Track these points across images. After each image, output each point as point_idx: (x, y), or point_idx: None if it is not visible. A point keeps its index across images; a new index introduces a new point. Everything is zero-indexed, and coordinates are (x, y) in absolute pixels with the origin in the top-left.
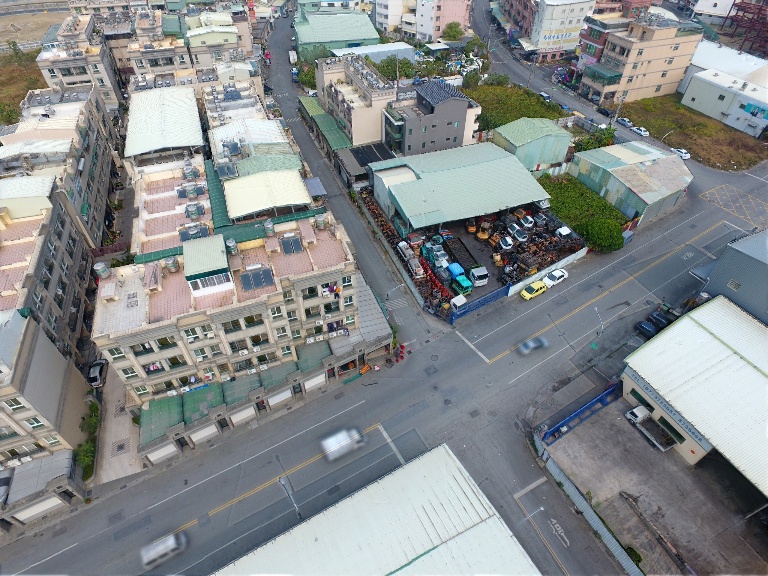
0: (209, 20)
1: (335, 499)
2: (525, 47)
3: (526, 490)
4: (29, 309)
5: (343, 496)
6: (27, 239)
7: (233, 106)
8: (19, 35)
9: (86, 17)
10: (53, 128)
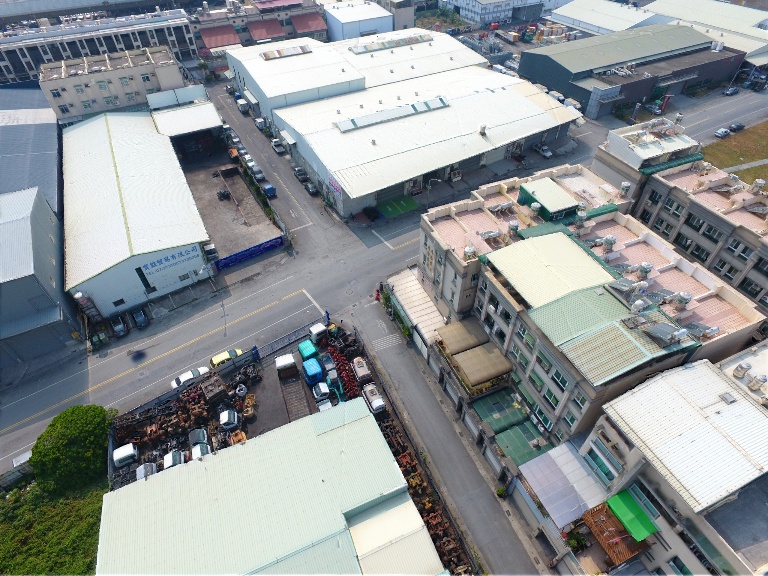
0: None
1: (415, 220)
2: None
3: (304, 226)
4: (644, 171)
5: (411, 221)
6: None
7: None
8: None
9: None
10: None
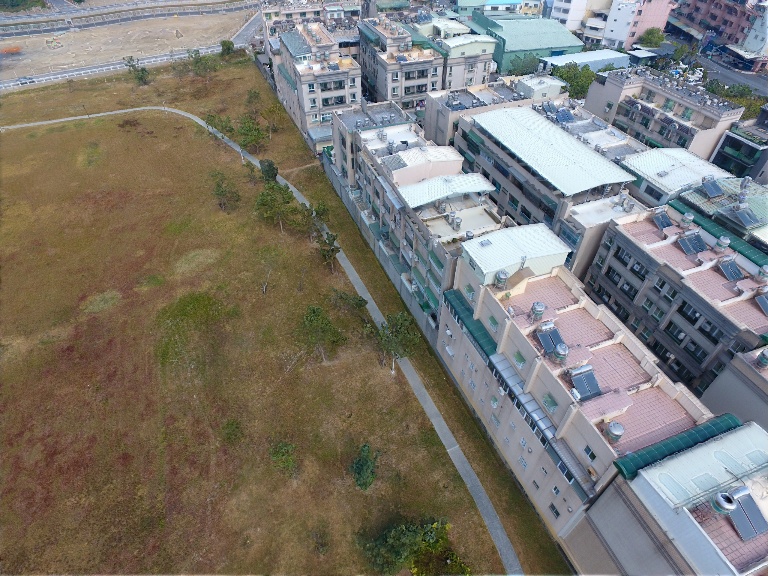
0: (449, 28)
1: None
2: (743, 55)
3: None
4: None
5: None
6: (571, 307)
7: (574, 128)
8: (166, 41)
9: (313, 25)
10: (445, 160)
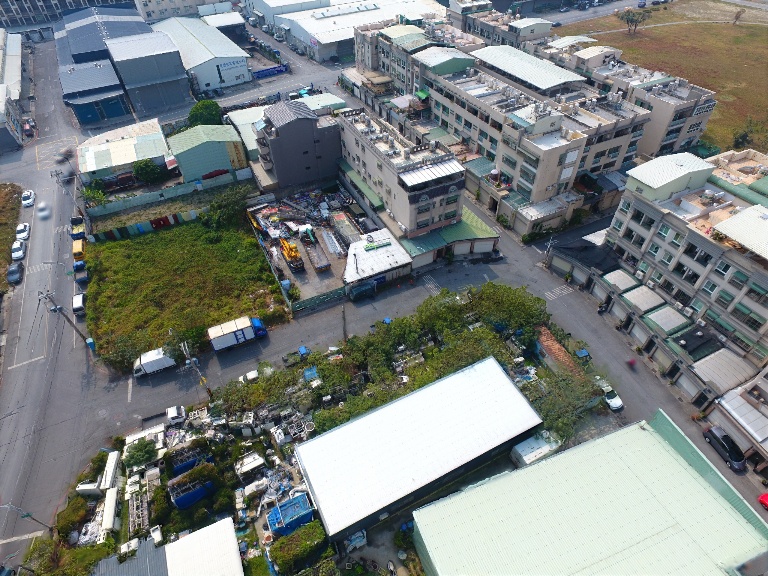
0: (749, 210)
1: None
2: None
3: None
4: None
5: None
6: None
7: None
8: None
9: None
10: None
